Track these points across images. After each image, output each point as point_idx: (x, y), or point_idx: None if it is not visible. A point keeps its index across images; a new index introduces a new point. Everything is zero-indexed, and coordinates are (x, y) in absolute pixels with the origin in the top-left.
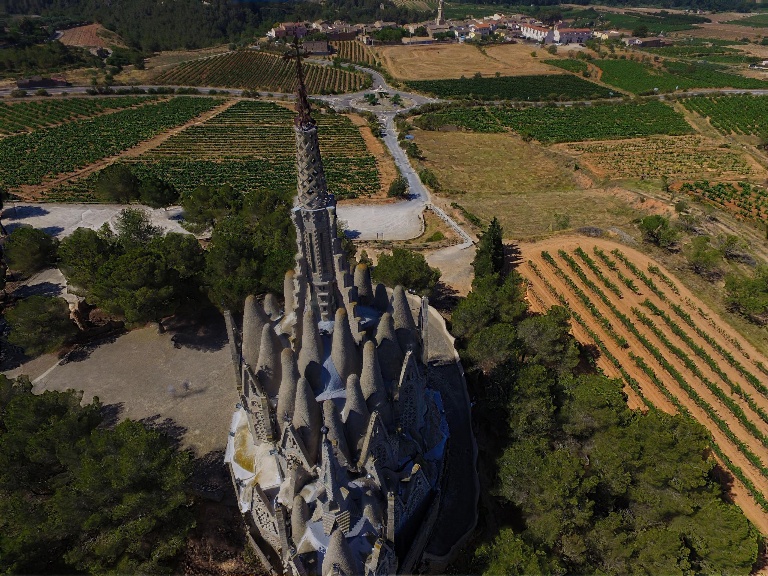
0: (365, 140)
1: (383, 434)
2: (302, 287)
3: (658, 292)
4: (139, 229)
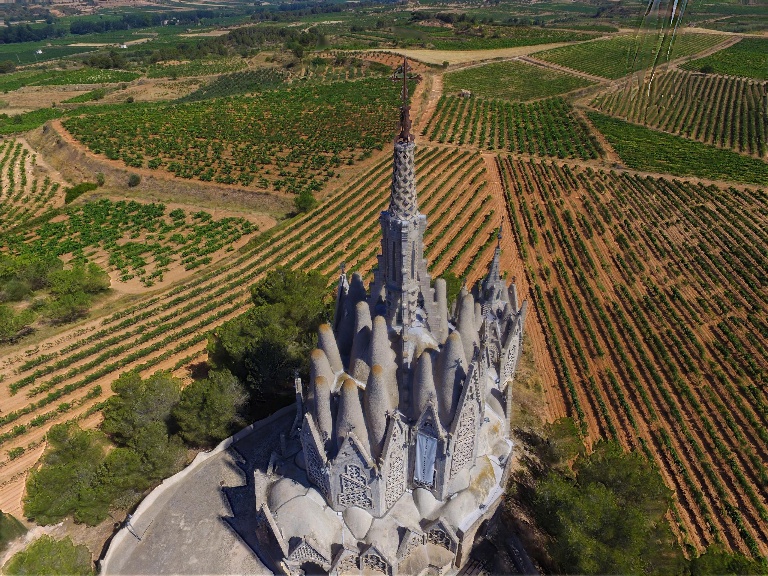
0: None
1: None
2: None
3: None
4: None
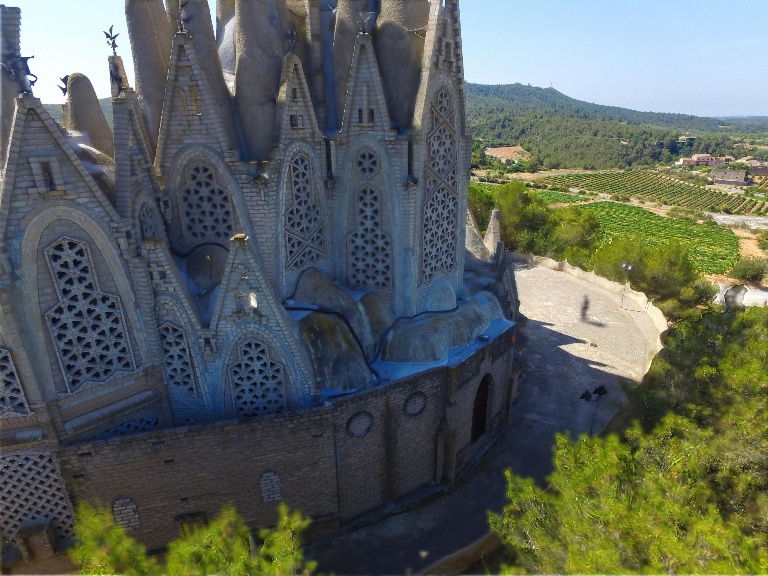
0: (742, 248)
1: (216, 133)
2: None
3: None
4: None
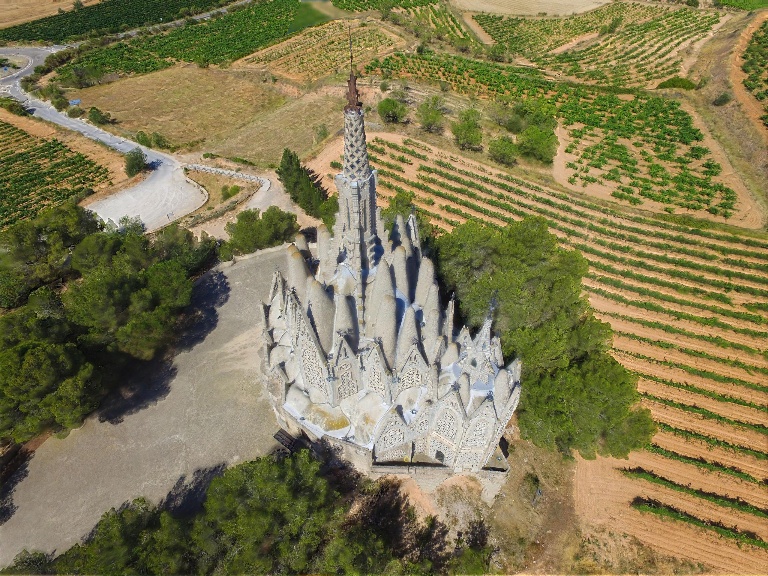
0: (12, 124)
1: None
2: None
3: (422, 156)
4: None
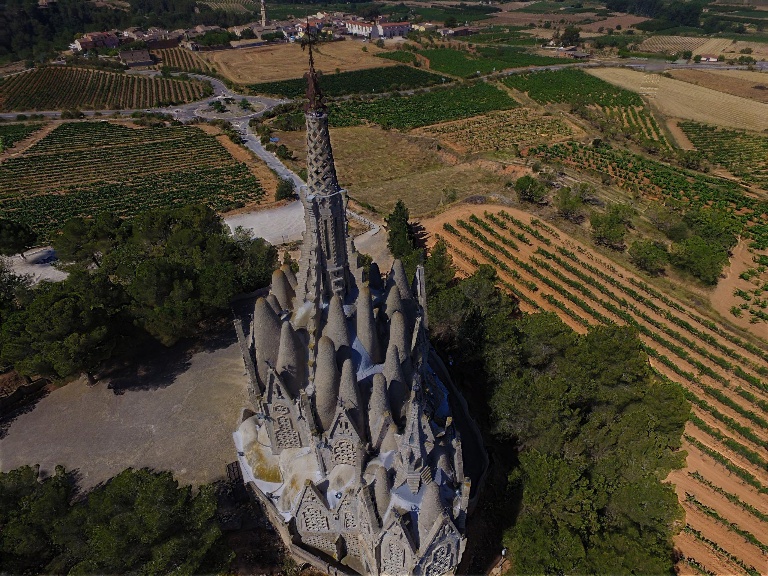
0: (227, 148)
1: (419, 397)
2: (318, 276)
3: (545, 240)
4: (0, 282)
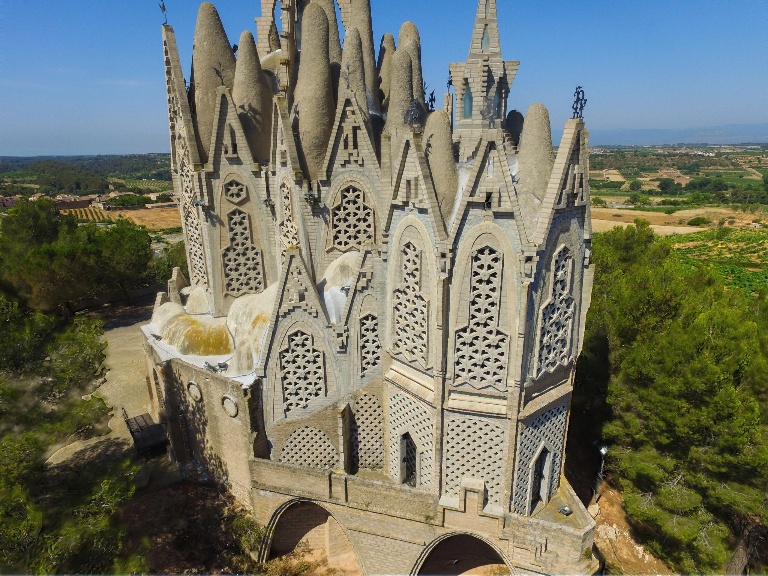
0: None
1: None
2: None
3: None
4: None
